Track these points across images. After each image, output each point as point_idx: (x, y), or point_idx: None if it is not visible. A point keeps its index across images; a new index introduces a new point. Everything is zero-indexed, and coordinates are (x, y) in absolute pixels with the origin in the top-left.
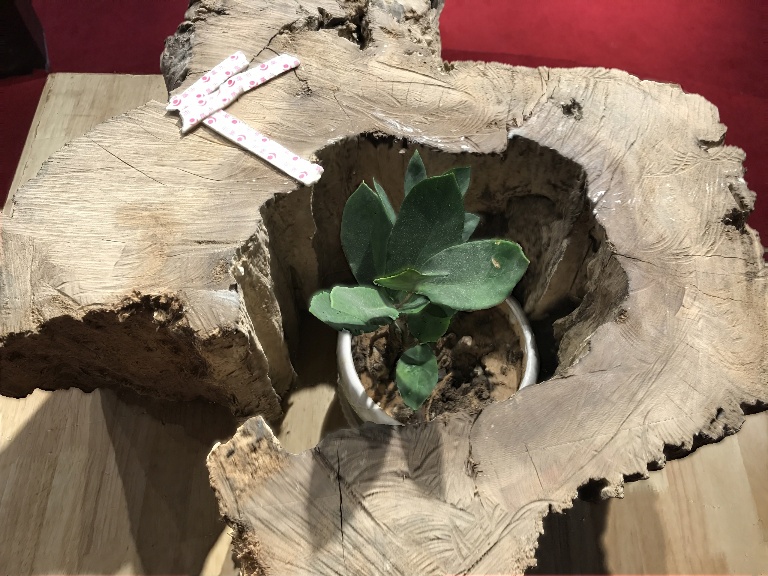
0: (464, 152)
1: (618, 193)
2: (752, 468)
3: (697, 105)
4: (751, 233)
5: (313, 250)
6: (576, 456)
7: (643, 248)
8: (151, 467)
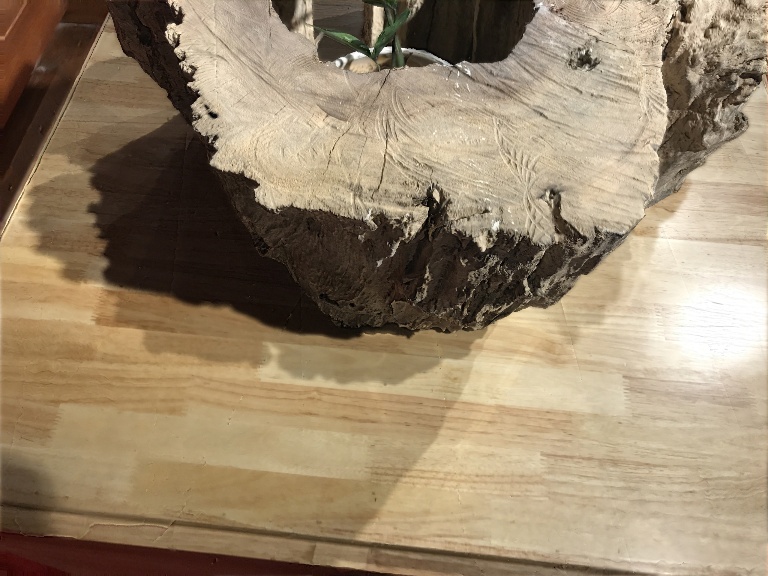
0: (535, 5)
1: (469, 87)
2: (259, 475)
3: (623, 207)
4: (414, 209)
5: (479, 10)
6: (203, 7)
7: (397, 93)
8: (350, 28)
